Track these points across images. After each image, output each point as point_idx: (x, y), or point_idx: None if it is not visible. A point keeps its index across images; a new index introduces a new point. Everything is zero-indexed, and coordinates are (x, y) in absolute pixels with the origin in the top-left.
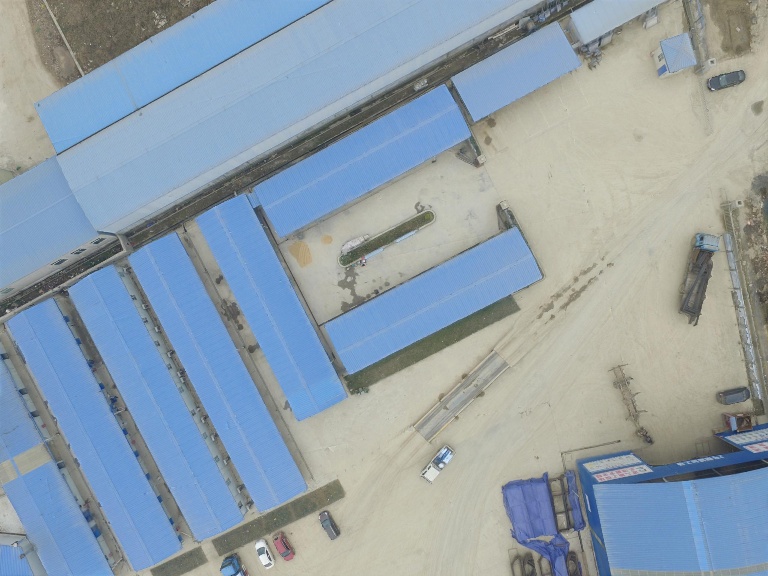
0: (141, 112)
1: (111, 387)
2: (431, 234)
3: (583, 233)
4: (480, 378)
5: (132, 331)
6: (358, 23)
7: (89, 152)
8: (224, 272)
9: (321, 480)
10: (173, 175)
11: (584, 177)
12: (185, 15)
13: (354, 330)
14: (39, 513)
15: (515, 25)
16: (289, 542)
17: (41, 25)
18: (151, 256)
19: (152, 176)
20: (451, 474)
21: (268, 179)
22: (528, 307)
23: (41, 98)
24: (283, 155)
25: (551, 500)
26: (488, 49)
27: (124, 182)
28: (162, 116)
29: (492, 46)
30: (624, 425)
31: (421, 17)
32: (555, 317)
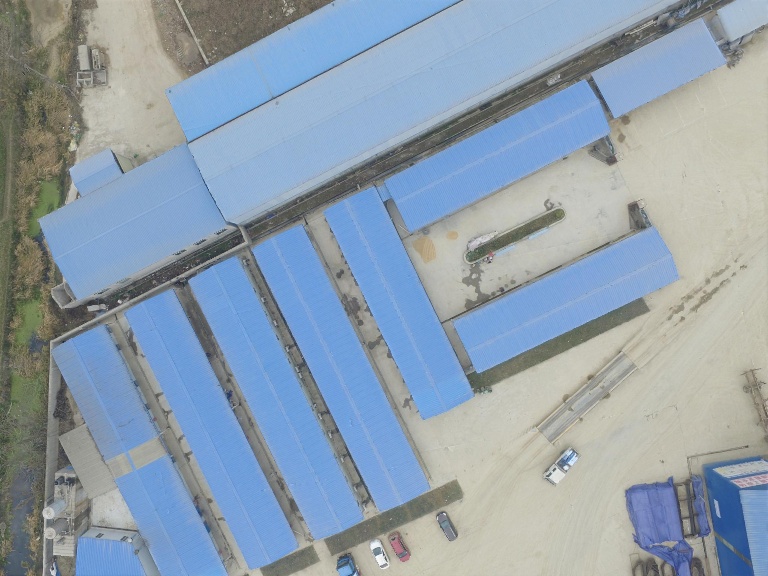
0: (277, 101)
1: (225, 381)
2: (560, 232)
3: (716, 234)
4: (607, 379)
5: (255, 324)
6: (506, 15)
7: (222, 140)
8: (351, 266)
9: (439, 480)
10: (309, 166)
11: (719, 177)
12: (315, 3)
13: (484, 328)
14: (153, 508)
15: (653, 21)
16: (405, 543)
17: (164, 10)
18: (277, 248)
19: (287, 166)
20: (573, 477)
21: (400, 172)
22: (658, 308)
23: (161, 85)
24: (410, 148)
25: (677, 505)
26: (624, 45)
27: (258, 172)
28: (299, 105)
29: (628, 42)
30: (753, 430)
31: (571, 10)
32: (685, 319)
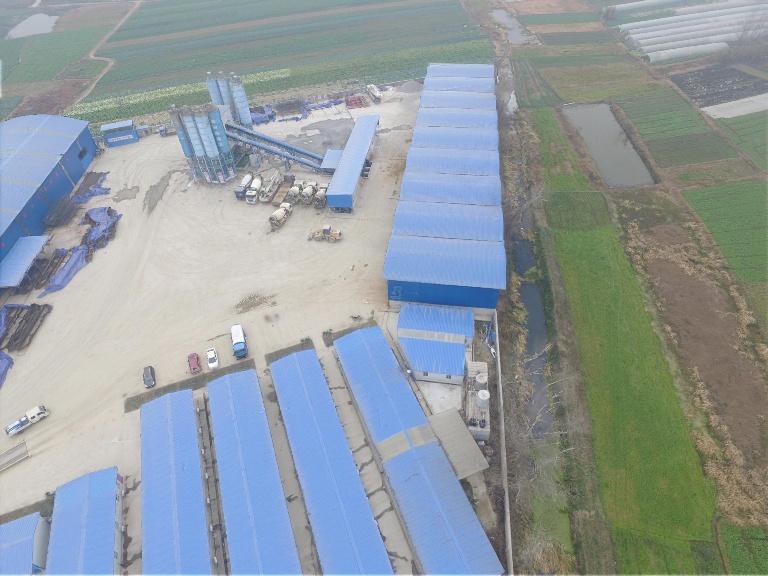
0: None
1: None
2: None
3: None
4: None
5: None
6: None
7: None
8: None
9: None
10: None
11: None
12: None
13: (1, 564)
14: (389, 397)
15: None
16: None
17: None
18: None
19: None
20: None
21: None
22: None
23: None
24: None
25: None
26: None
27: None
28: None
29: None
30: None
31: None
32: None
